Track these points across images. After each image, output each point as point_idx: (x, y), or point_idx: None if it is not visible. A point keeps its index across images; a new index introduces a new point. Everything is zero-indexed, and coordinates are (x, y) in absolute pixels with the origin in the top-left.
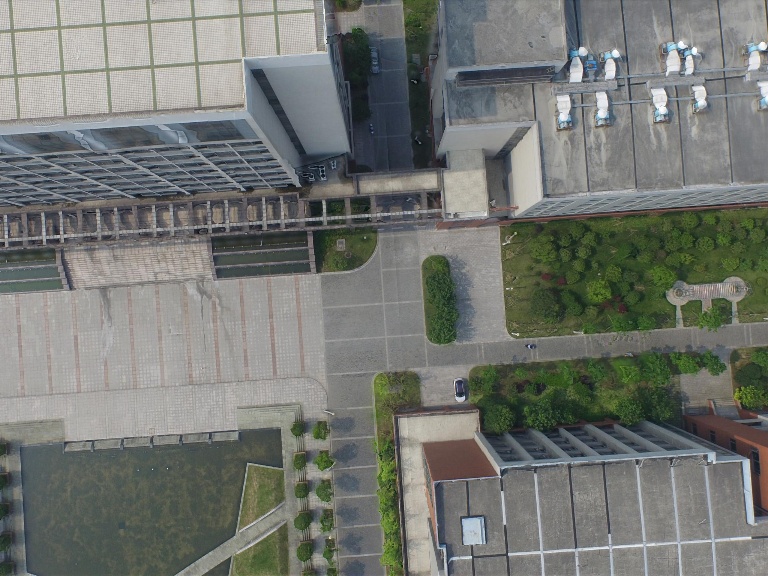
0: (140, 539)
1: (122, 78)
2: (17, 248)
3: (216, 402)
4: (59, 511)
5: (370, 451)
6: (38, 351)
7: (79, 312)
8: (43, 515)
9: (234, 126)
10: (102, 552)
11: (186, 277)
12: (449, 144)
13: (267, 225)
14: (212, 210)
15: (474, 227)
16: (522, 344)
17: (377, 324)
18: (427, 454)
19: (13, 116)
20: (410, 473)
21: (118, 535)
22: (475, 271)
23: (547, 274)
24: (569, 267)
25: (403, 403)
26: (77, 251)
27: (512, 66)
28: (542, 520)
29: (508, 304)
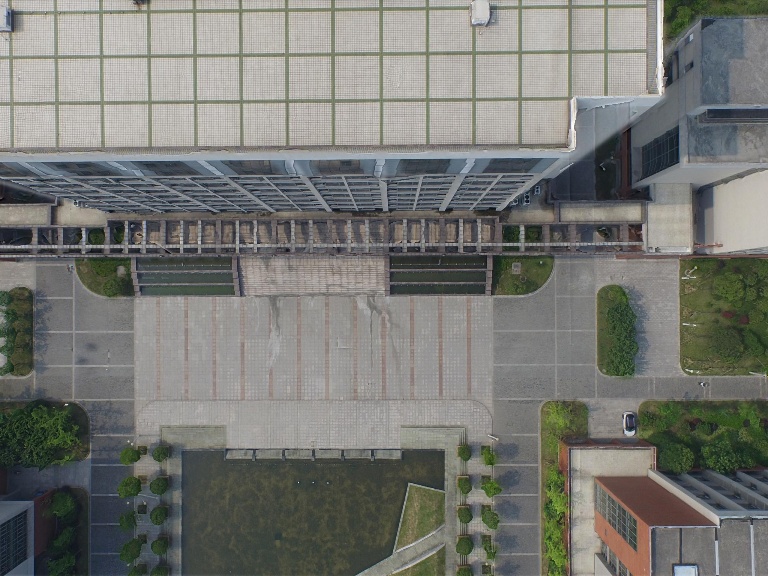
0: (296, 551)
1: (442, 109)
2: (211, 255)
3: (380, 419)
4: (216, 518)
5: (532, 479)
6: (204, 356)
7: (247, 319)
8: (200, 520)
9: (530, 161)
10: (257, 562)
11: (358, 291)
12: (664, 178)
13: (463, 247)
14: (394, 226)
15: (654, 259)
16: (695, 381)
17: (548, 351)
18: (613, 491)
19: (328, 142)
20: (579, 506)
21: (274, 546)
22: (651, 303)
23: (728, 312)
24: (750, 306)
25: (570, 433)
26: (253, 258)
27: (766, 106)
28: (756, 573)
29: (684, 339)
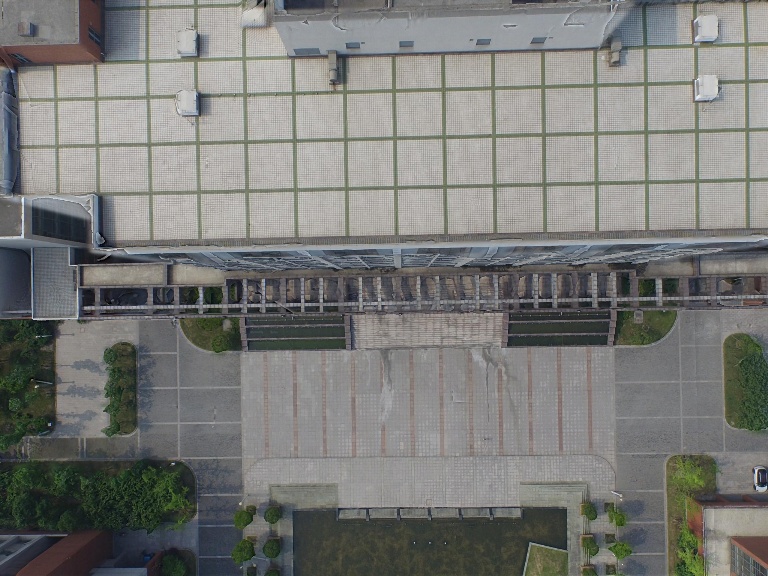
0: None
1: (662, 192)
2: (335, 314)
3: (498, 476)
4: None
5: (659, 537)
6: (313, 411)
7: (358, 373)
8: None
9: None
10: None
11: (473, 343)
12: None
13: (598, 302)
14: None
15: None
16: None
17: (672, 403)
18: (761, 558)
19: (539, 229)
20: (715, 568)
21: None
22: None
23: None
24: None
25: (698, 489)
26: (365, 311)
27: None
28: None
29: None
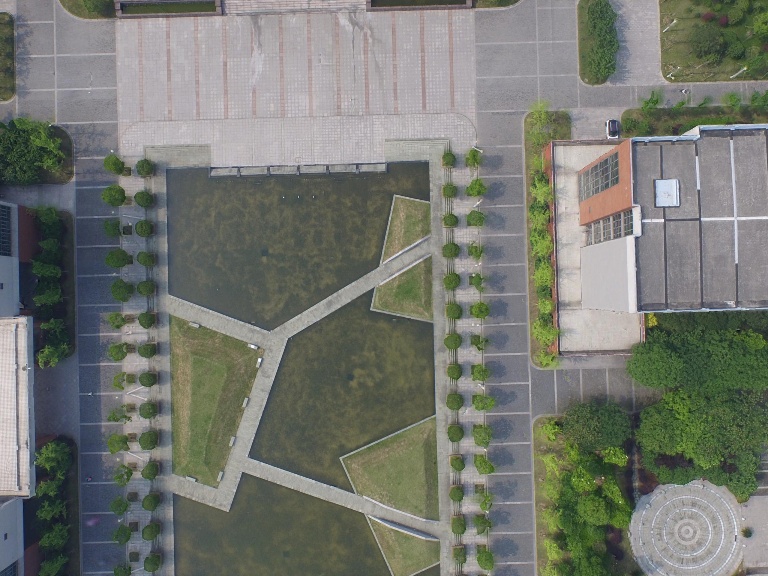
0: (283, 267)
1: None
2: None
3: (364, 134)
4: (202, 236)
5: (517, 190)
6: (187, 76)
7: (229, 38)
8: (186, 239)
9: None
10: (244, 278)
11: (339, 6)
12: None
13: None
14: None
15: None
16: (677, 89)
17: (530, 63)
18: None
19: None
20: (564, 202)
21: (261, 262)
22: (632, 13)
23: None
24: (729, 10)
25: None
26: None
27: None
28: (737, 186)
29: (664, 47)
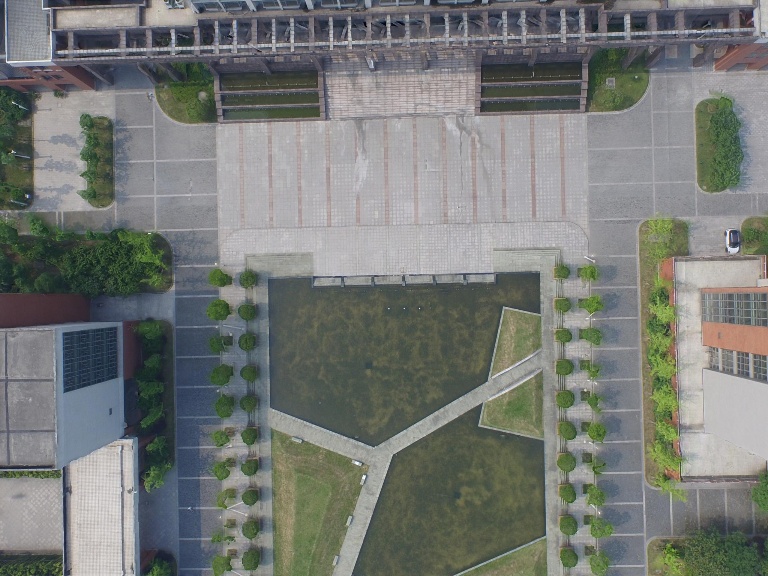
0: (387, 380)
1: None
2: (305, 52)
3: (472, 243)
4: (305, 347)
5: (631, 302)
6: (289, 182)
7: (333, 143)
8: (288, 350)
9: None
10: (347, 392)
11: (447, 110)
12: None
13: (566, 38)
14: None
15: (755, 70)
16: None
17: (645, 169)
18: None
19: None
20: (686, 320)
21: (365, 375)
22: (752, 117)
23: None
24: None
25: (670, 252)
26: (339, 76)
27: None
28: None
29: None
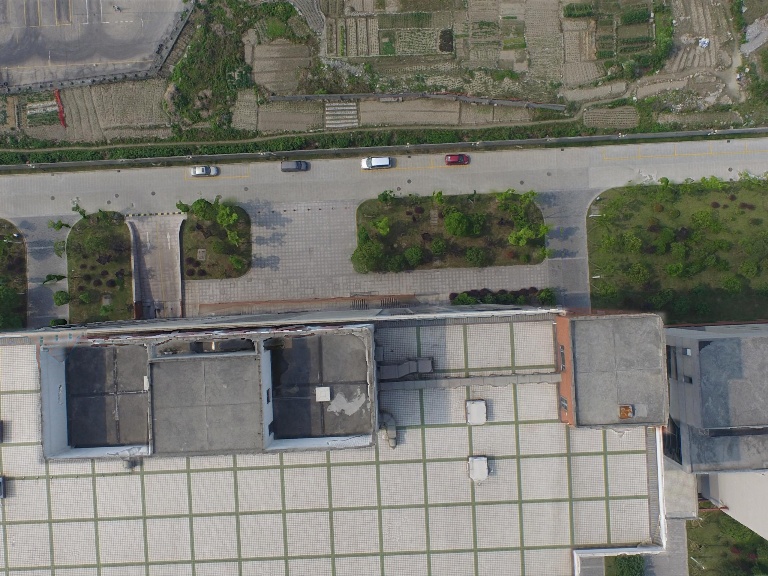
0: None
1: (443, 561)
2: None
3: None
4: None
5: None
6: None
7: None
8: None
9: None
10: None
11: None
12: None
13: None
14: None
15: None
16: None
17: None
18: None
19: None
20: None
21: None
22: None
23: (736, 547)
24: (758, 539)
25: None
26: None
27: None
28: None
29: (692, 573)
